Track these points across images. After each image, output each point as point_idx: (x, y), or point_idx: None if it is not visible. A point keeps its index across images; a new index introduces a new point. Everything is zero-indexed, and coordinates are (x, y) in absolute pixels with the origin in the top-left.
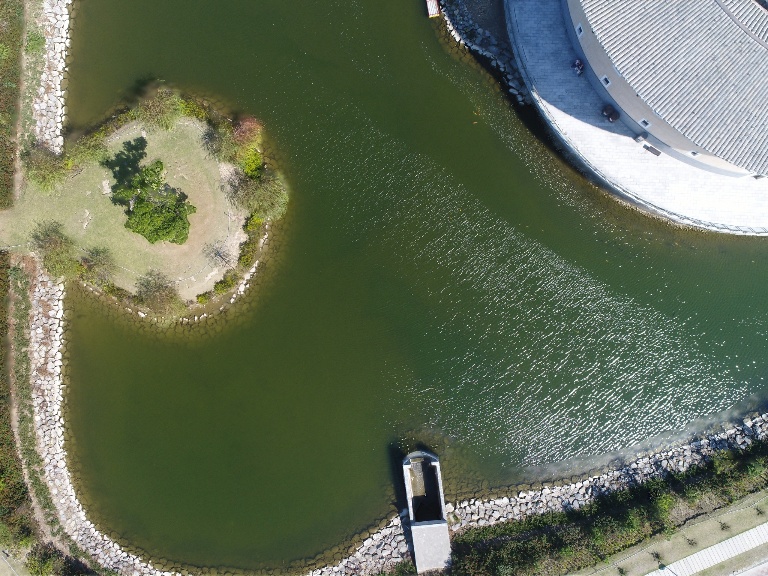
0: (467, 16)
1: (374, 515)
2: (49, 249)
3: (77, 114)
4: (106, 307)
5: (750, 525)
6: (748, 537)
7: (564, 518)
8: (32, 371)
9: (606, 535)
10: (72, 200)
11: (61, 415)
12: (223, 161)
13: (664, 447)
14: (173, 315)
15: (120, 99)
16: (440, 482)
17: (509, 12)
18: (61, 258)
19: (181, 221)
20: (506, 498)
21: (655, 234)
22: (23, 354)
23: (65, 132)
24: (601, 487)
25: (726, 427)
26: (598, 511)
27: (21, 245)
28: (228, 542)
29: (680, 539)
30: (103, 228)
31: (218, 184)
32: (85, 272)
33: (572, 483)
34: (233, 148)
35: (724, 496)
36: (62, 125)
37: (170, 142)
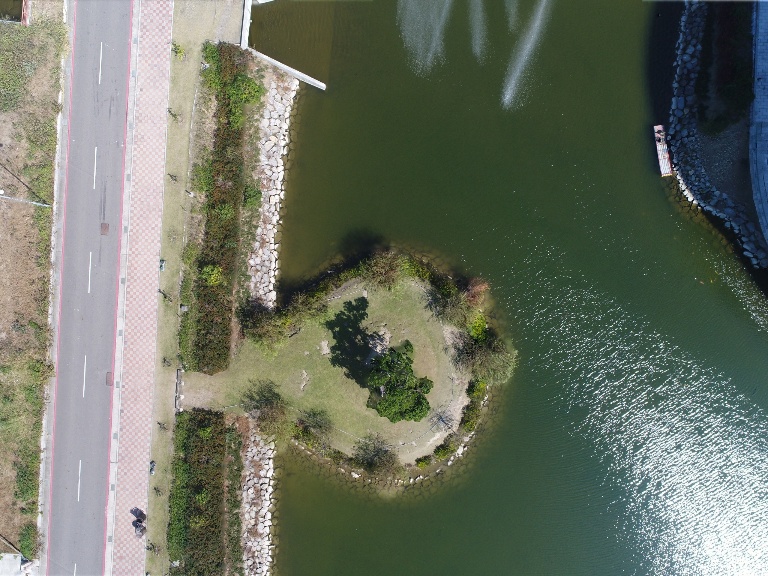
0: (704, 178)
1: None
2: (264, 410)
3: (289, 267)
4: (317, 466)
5: None
6: None
7: None
8: (243, 533)
9: None
10: (289, 360)
11: (270, 575)
12: (448, 324)
13: None
14: (388, 477)
15: (334, 253)
16: None
17: (758, 182)
18: (275, 418)
19: (425, 401)
20: None
21: None
22: (235, 516)
23: (277, 286)
24: None
25: None
26: None
27: (236, 405)
28: None
29: None
30: (321, 390)
31: (442, 347)
32: (302, 434)
33: None
34: (463, 314)
35: None
36: (275, 279)
37: (392, 303)
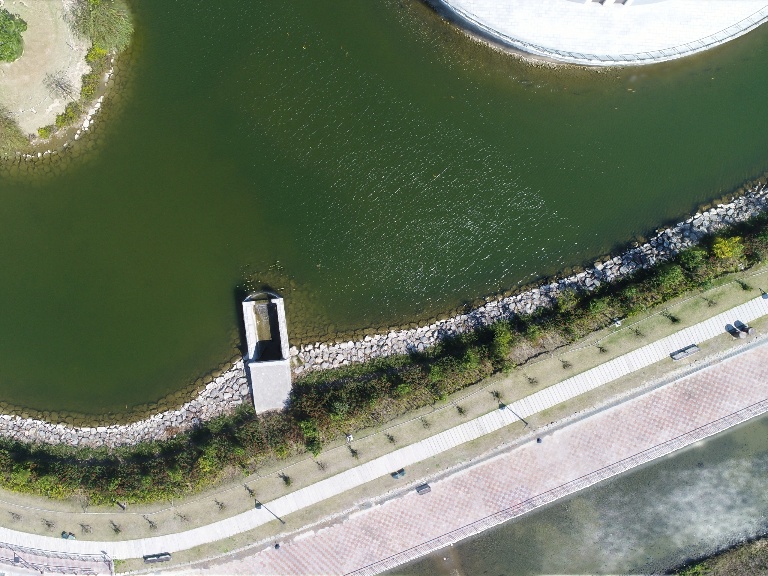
0: None
1: (218, 359)
2: None
3: None
4: None
5: (592, 364)
6: (590, 376)
7: (407, 360)
8: None
9: (446, 373)
10: None
11: None
12: None
13: (514, 291)
14: (16, 151)
15: None
16: (280, 320)
17: None
18: None
19: (6, 34)
20: (351, 342)
21: (508, 72)
22: None
23: None
24: (447, 330)
25: (577, 271)
26: (442, 353)
27: None
28: (71, 387)
29: (521, 378)
30: None
31: (60, 13)
32: None
33: (419, 327)
34: None
35: (568, 335)
36: None
37: None
